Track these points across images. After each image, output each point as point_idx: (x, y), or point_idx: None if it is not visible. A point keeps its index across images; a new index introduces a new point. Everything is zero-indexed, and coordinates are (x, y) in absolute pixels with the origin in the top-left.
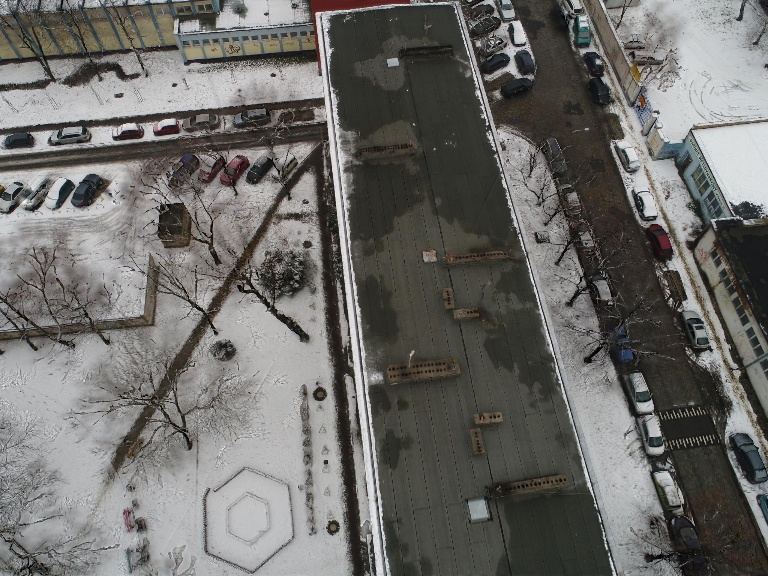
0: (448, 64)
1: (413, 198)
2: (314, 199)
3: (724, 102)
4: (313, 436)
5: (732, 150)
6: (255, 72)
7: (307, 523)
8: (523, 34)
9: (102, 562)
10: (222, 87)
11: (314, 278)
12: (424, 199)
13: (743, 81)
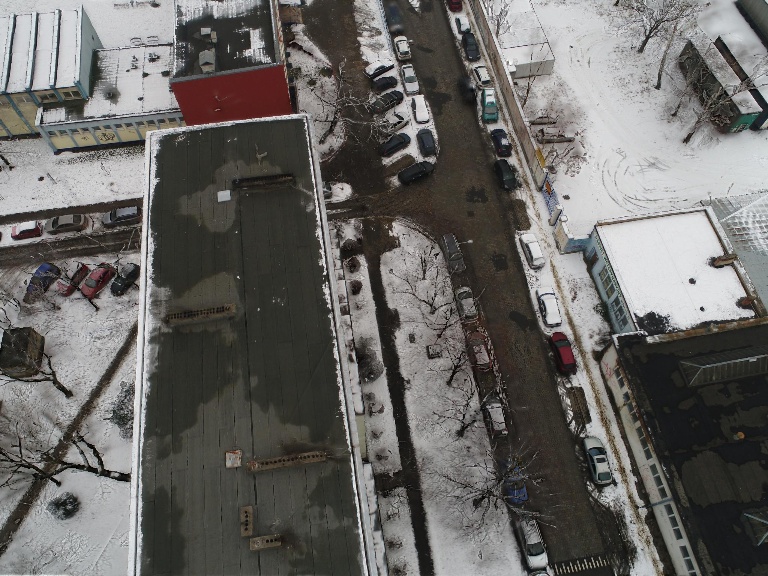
0: (288, 196)
1: (225, 378)
2: None
3: (639, 183)
4: None
5: (639, 250)
6: (131, 161)
7: None
8: (426, 110)
9: None
10: (93, 180)
11: None
12: (237, 379)
13: (660, 158)
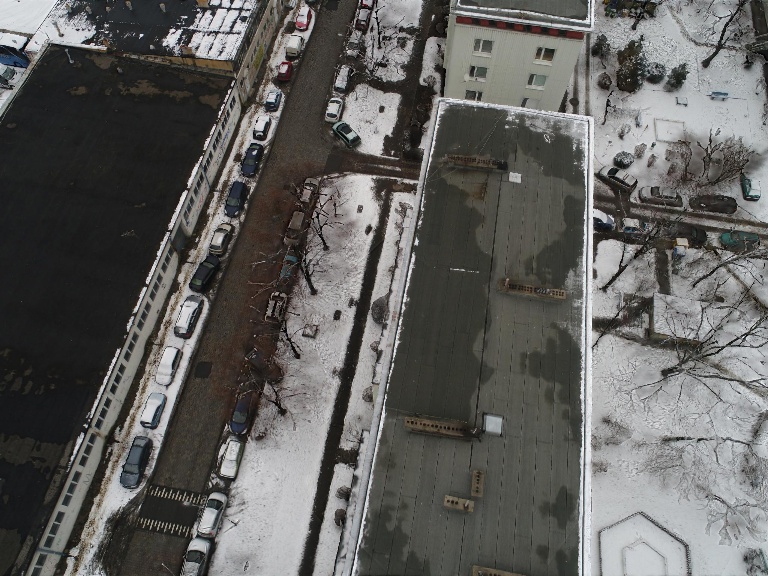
0: None
1: None
2: None
3: None
4: None
5: None
6: None
7: None
8: None
9: None
10: None
11: None
12: None
13: None
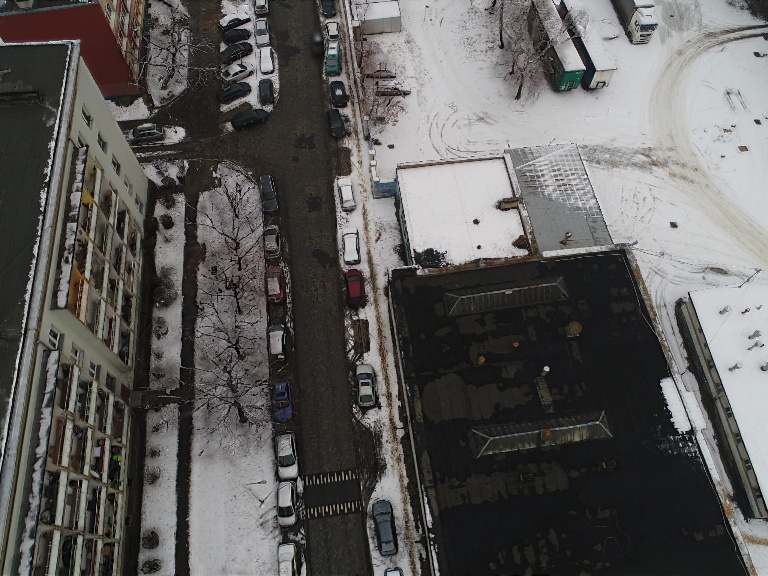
0: (32, 111)
1: None
2: None
3: (464, 136)
4: None
5: (432, 192)
6: None
7: None
8: (270, 61)
9: None
10: None
11: None
12: None
13: (490, 113)
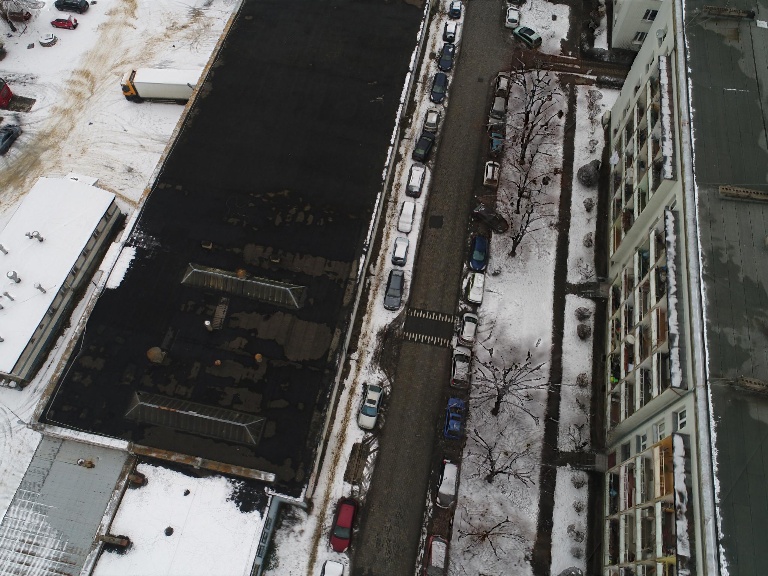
0: None
1: None
2: None
3: None
4: None
5: None
6: None
7: None
8: None
9: None
10: None
11: None
12: None
13: None
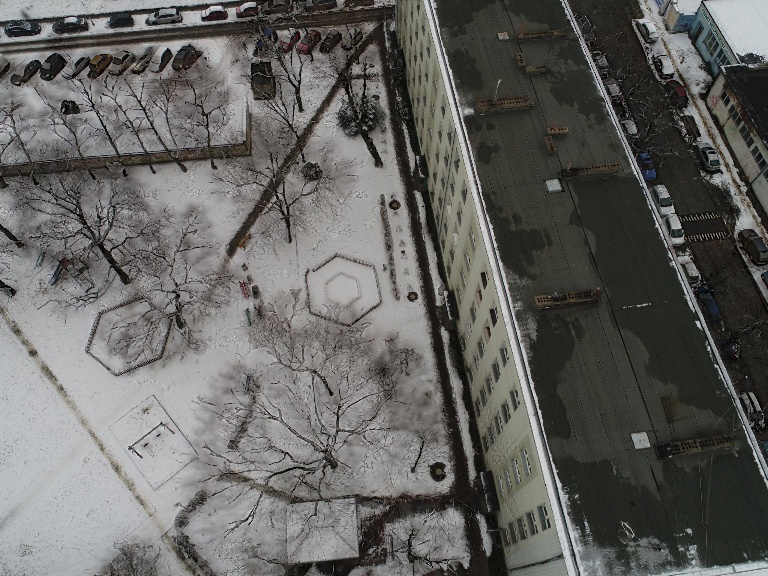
0: None
1: None
2: (379, 64)
3: None
4: (392, 232)
5: (738, 15)
6: None
7: (392, 291)
8: None
9: (226, 319)
10: None
11: (384, 119)
12: (495, 0)
13: None
